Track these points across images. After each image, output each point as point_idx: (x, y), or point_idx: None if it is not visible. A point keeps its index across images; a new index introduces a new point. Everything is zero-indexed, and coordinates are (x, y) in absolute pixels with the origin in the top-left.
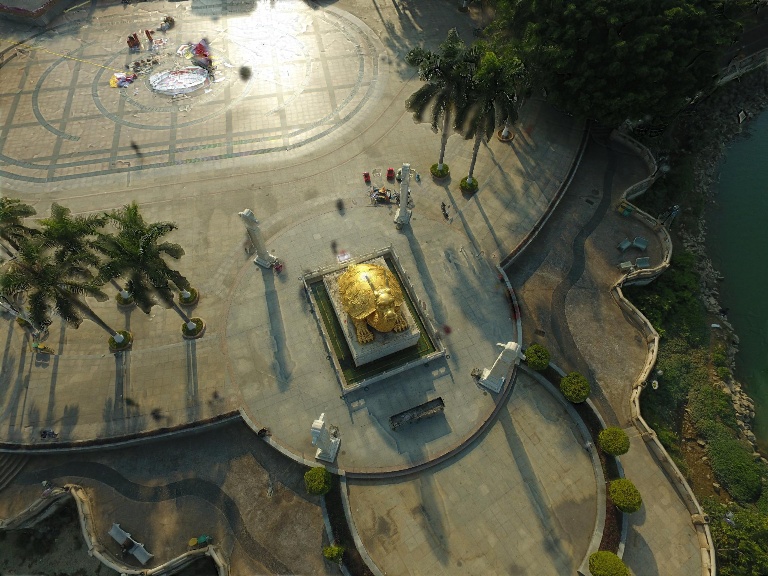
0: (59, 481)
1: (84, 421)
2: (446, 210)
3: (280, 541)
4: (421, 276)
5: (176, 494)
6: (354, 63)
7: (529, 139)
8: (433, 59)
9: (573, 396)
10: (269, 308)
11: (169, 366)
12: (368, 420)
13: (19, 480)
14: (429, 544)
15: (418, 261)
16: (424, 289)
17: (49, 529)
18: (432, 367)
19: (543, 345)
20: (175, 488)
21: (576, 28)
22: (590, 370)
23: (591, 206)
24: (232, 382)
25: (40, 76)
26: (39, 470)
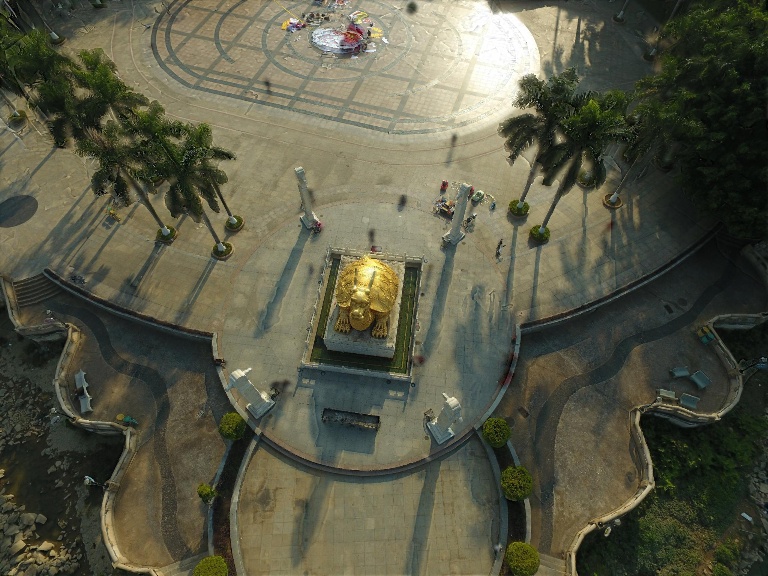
0: (70, 318)
1: (107, 282)
2: (501, 248)
3: (183, 458)
4: (436, 299)
5: (135, 374)
6: (500, 75)
7: (637, 215)
8: (534, 89)
9: (507, 490)
10: (288, 263)
11: (187, 271)
12: (308, 401)
13: (47, 303)
14: (292, 538)
15: (442, 284)
16: (431, 312)
17: (49, 350)
18: (393, 386)
19: (519, 426)
20: (137, 369)
21: (742, 112)
22: (553, 477)
23: (668, 314)
24: (223, 309)
25: (236, 2)
26: (63, 303)
